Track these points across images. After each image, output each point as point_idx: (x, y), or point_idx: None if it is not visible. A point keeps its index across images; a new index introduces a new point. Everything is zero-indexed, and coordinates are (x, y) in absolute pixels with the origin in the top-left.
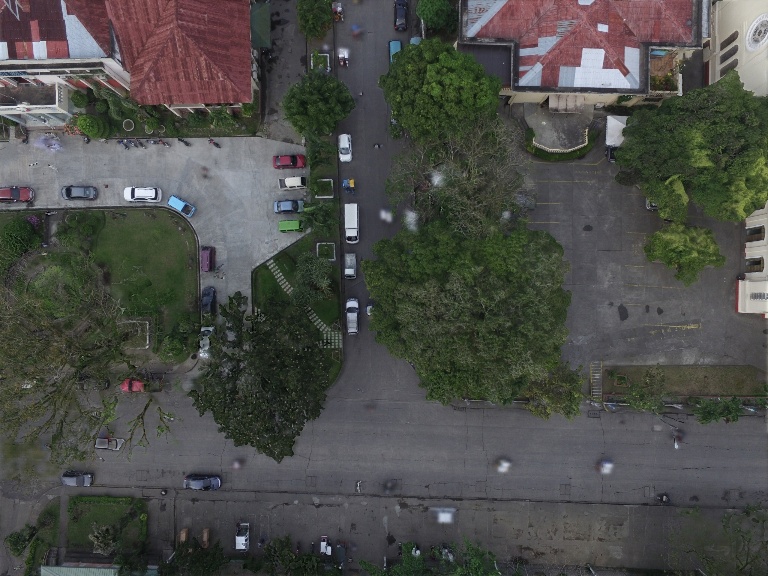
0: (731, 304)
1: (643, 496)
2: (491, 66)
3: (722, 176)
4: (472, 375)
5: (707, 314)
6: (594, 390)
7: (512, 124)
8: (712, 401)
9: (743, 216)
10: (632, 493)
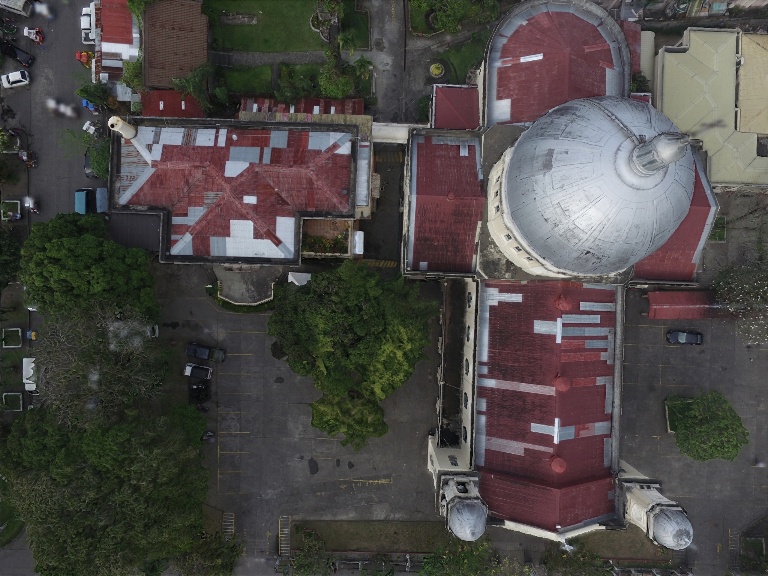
0: (423, 459)
1: None
2: (146, 233)
3: (345, 363)
4: (65, 574)
5: (398, 469)
6: (282, 545)
7: (204, 274)
8: (400, 558)
9: (380, 397)
10: None
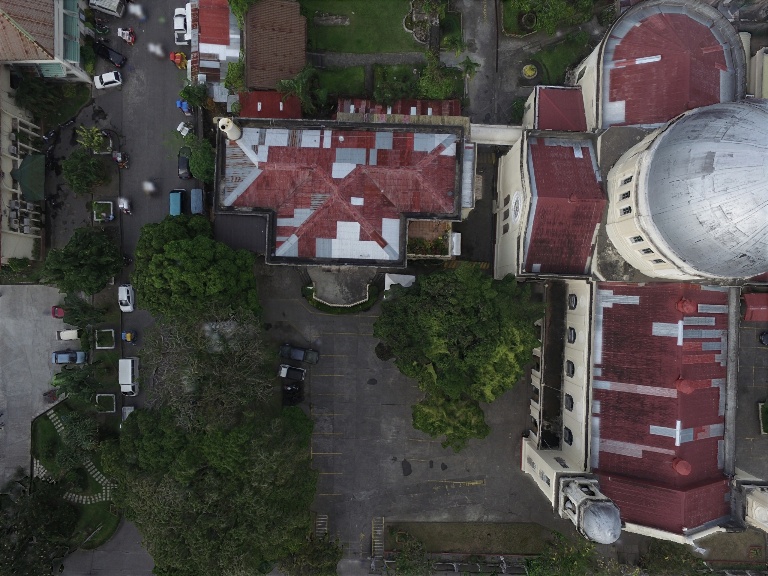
0: (516, 460)
1: None
2: (250, 234)
3: (460, 365)
4: None
5: (492, 470)
6: (375, 546)
7: (297, 275)
8: (494, 560)
9: (490, 399)
10: None
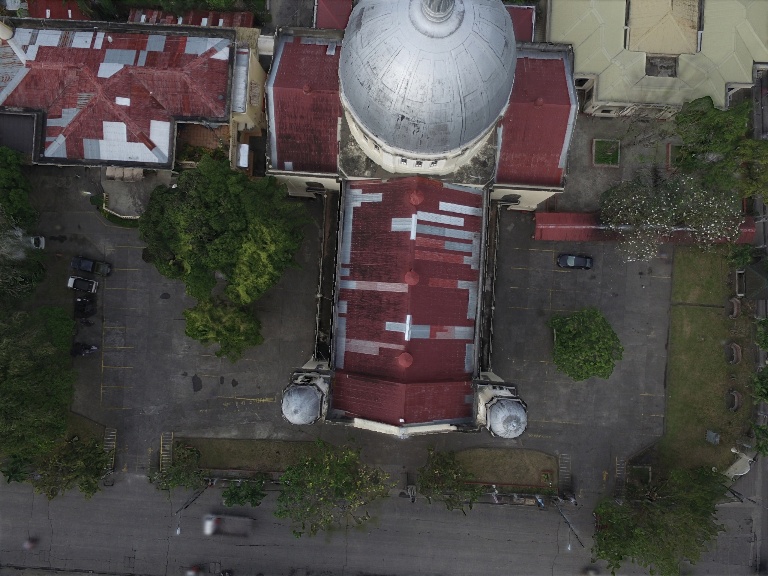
0: None
1: (208, 572)
2: (21, 135)
3: (205, 261)
4: None
5: None
6: (163, 462)
7: (93, 187)
8: None
9: (245, 300)
10: (197, 568)
